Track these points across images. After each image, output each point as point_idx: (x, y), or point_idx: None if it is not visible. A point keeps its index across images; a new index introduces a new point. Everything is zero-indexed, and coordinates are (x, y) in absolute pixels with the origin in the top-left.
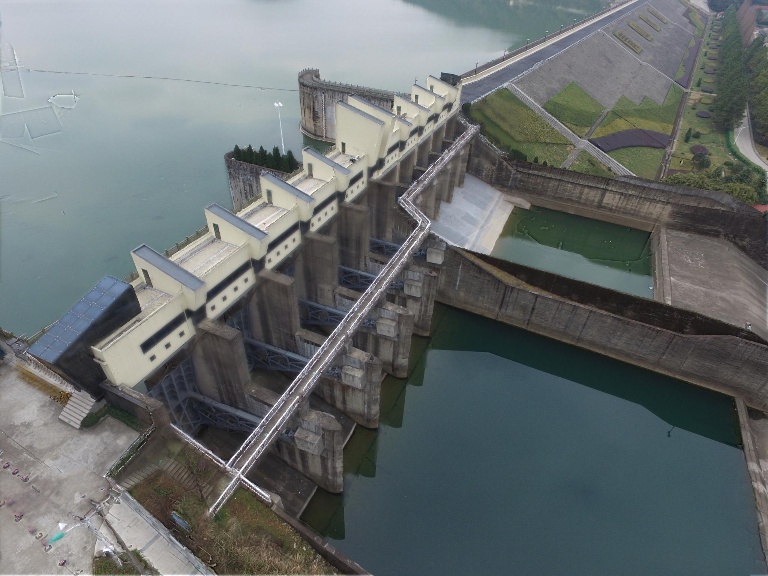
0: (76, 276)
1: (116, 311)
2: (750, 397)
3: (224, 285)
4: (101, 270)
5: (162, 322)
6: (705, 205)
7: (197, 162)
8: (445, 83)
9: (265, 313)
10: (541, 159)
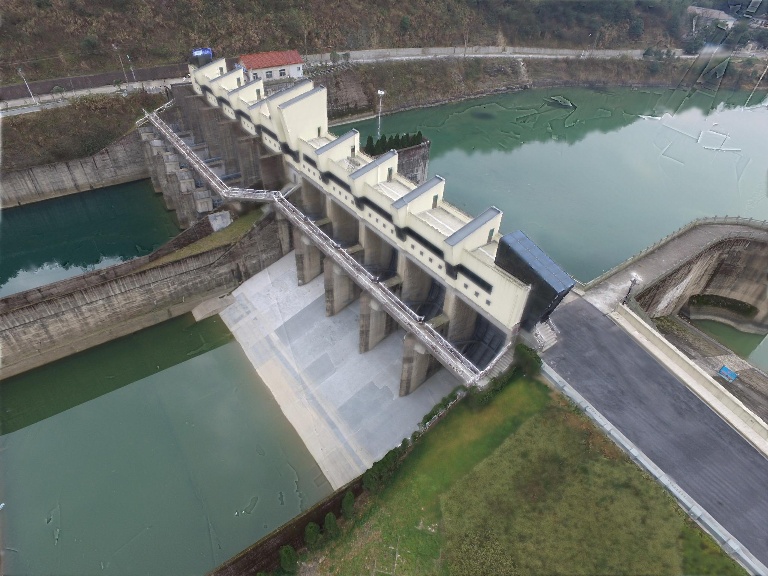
0: None
1: None
2: None
3: None
4: None
5: None
6: None
7: (568, 203)
8: (473, 230)
9: None
10: (379, 567)
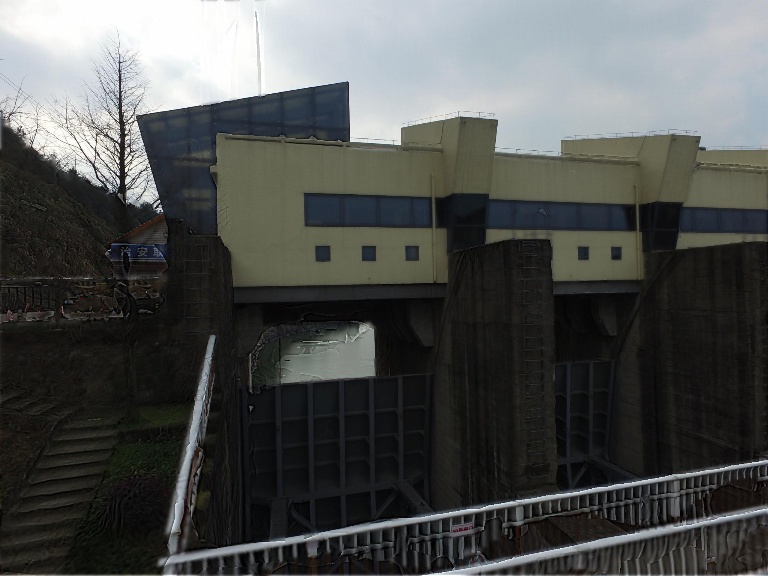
0: None
1: (302, 122)
2: None
3: (554, 224)
4: None
5: (374, 183)
6: None
7: None
8: None
9: (658, 381)
10: None
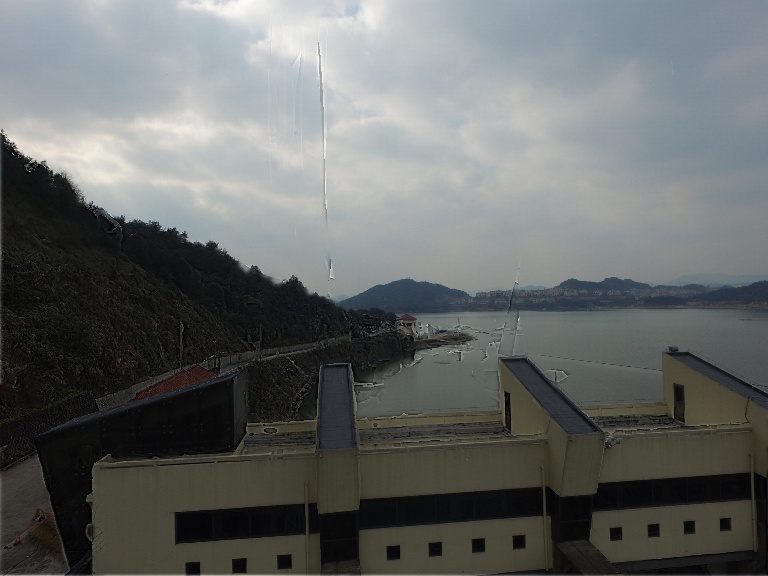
0: None
1: (190, 418)
2: None
3: (447, 513)
4: None
5: (246, 494)
6: None
7: None
8: None
9: None
10: None
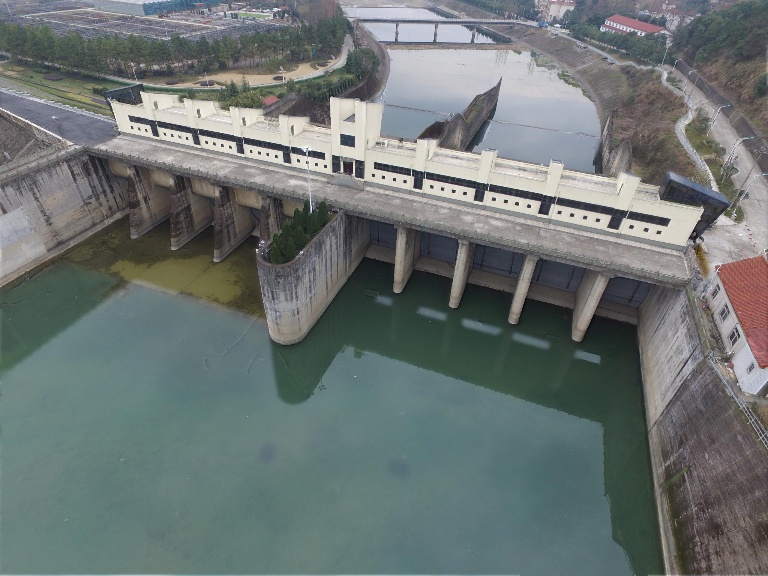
0: (451, 495)
1: None
2: (452, 147)
3: None
4: (434, 462)
5: None
6: (290, 105)
7: None
8: None
9: None
10: None
